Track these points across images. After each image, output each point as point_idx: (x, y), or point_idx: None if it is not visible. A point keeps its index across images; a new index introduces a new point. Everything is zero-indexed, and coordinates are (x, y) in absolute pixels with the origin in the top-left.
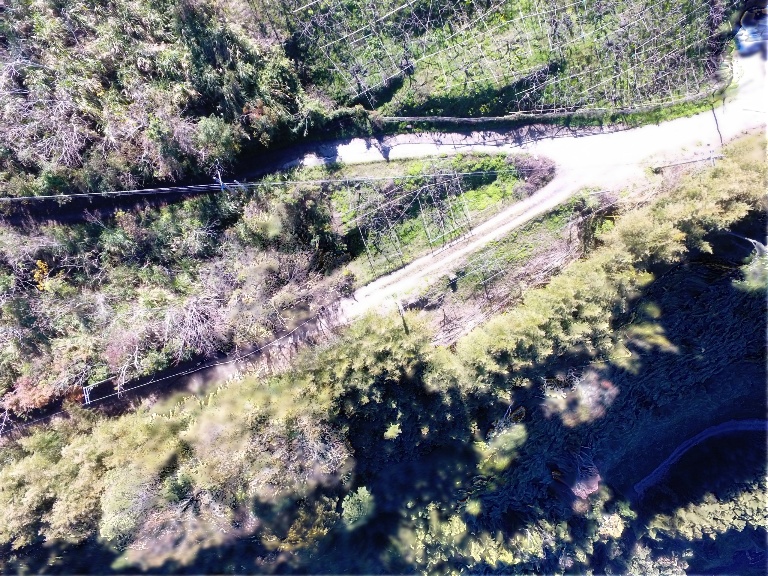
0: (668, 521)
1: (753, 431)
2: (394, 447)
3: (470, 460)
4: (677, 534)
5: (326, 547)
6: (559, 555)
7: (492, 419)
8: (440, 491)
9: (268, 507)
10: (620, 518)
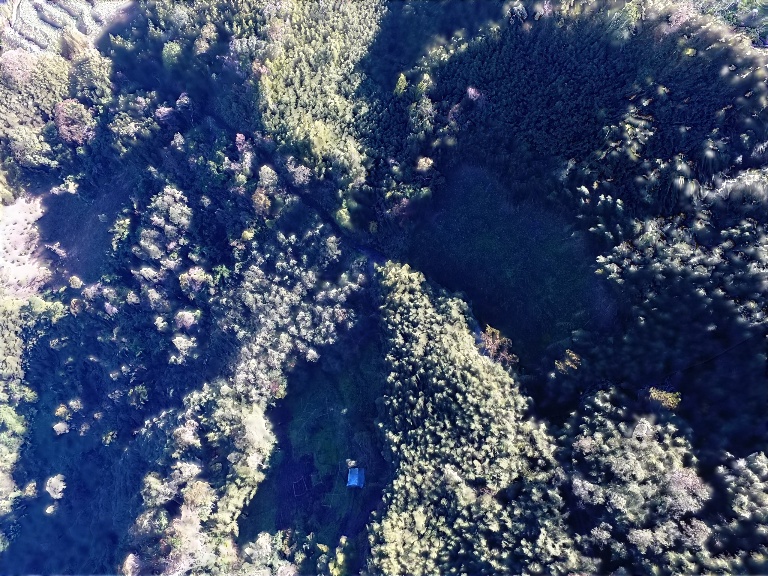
0: (397, 265)
1: None
2: None
3: None
4: None
5: (448, 6)
6: None
7: None
8: None
9: None
10: None
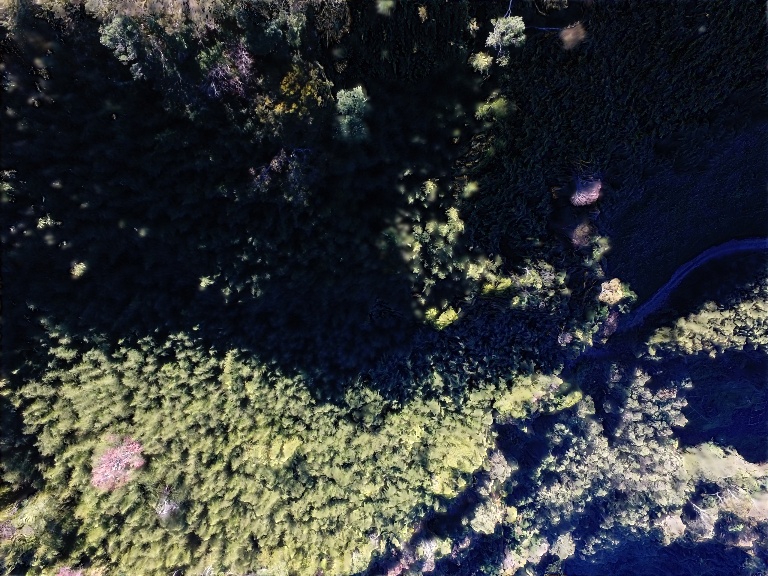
0: (668, 332)
1: (754, 249)
2: (390, 6)
3: (468, 103)
4: (677, 349)
5: (321, 196)
6: (558, 333)
7: (491, 12)
8: (438, 163)
9: (260, 38)
10: (620, 283)
